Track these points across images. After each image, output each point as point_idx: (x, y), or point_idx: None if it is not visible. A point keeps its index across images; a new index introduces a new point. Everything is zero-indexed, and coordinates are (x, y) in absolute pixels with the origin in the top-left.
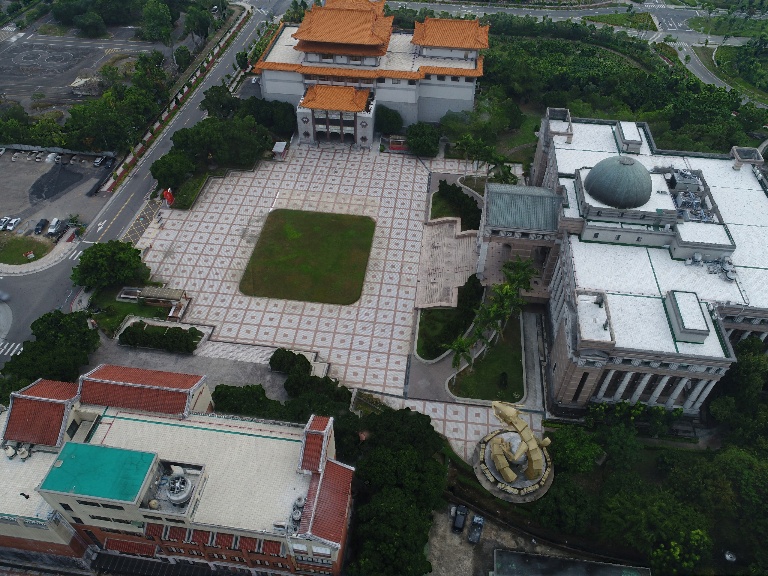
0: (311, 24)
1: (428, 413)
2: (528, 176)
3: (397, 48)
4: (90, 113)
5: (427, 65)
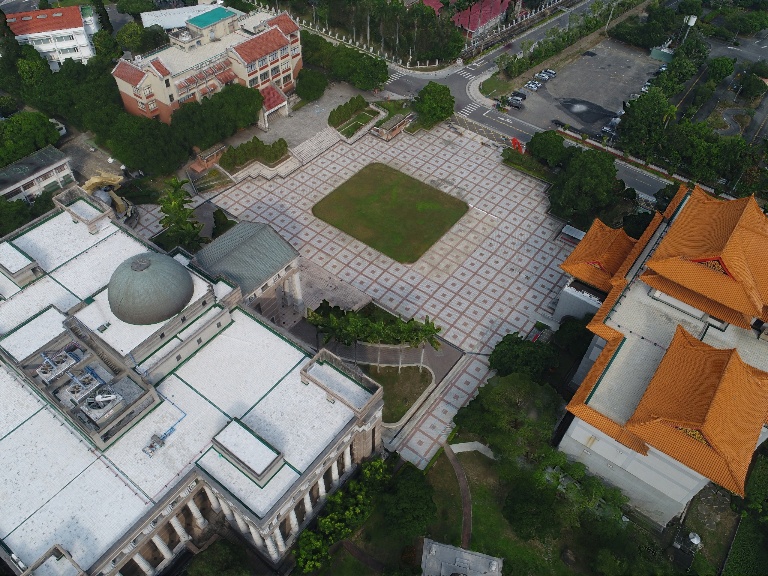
0: (720, 202)
1: (185, 205)
2: (390, 458)
3: (718, 348)
4: (645, 100)
5: (635, 355)
